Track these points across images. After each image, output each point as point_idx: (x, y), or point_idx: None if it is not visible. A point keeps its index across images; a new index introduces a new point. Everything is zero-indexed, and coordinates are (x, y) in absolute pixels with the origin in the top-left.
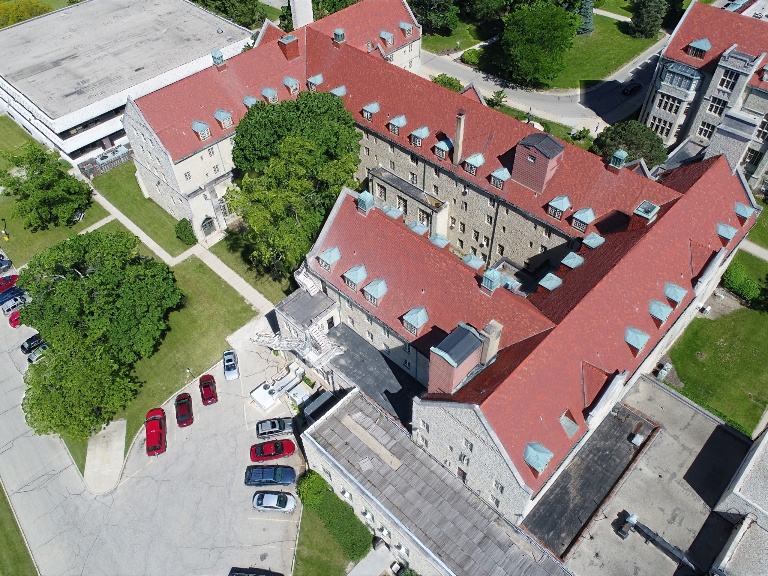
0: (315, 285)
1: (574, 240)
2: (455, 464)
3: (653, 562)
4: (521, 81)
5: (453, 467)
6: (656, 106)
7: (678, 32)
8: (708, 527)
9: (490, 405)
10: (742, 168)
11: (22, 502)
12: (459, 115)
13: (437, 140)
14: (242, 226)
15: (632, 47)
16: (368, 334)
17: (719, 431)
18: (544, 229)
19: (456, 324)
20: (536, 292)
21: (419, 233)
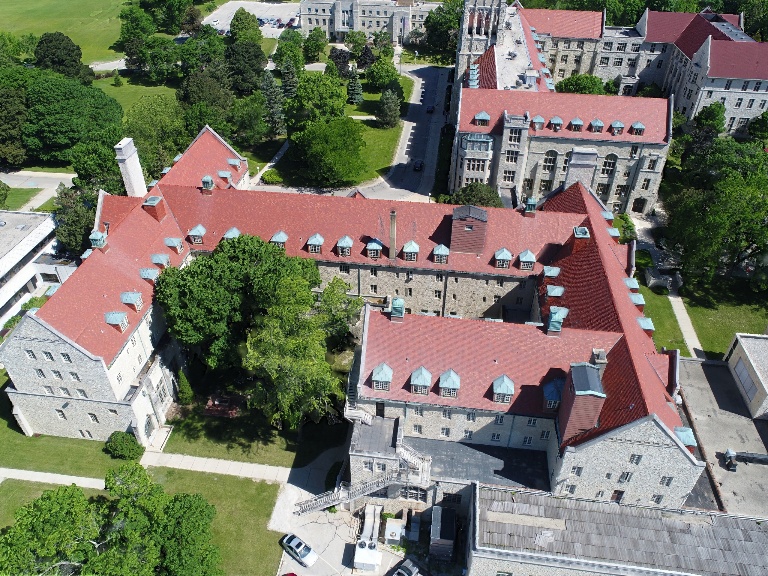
0: (367, 413)
1: (527, 279)
2: (611, 490)
3: (762, 474)
4: (331, 184)
5: (607, 495)
6: (466, 170)
7: (461, 112)
8: (761, 431)
9: (651, 411)
10: (541, 195)
11: None
12: (392, 213)
13: (363, 244)
14: (181, 410)
15: (389, 136)
16: (441, 432)
17: (705, 367)
18: (496, 281)
19: (541, 374)
20: None
21: None
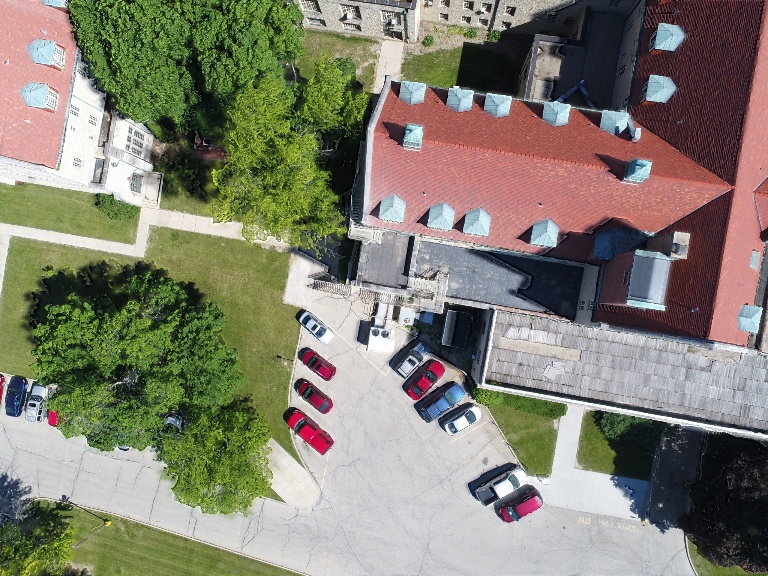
0: (376, 231)
1: None
2: None
3: None
4: None
5: None
6: None
7: None
8: None
9: (714, 325)
10: None
11: (256, 550)
12: None
13: None
14: (167, 151)
15: None
16: None
17: None
18: None
19: (598, 223)
20: (641, 106)
21: (469, 108)
